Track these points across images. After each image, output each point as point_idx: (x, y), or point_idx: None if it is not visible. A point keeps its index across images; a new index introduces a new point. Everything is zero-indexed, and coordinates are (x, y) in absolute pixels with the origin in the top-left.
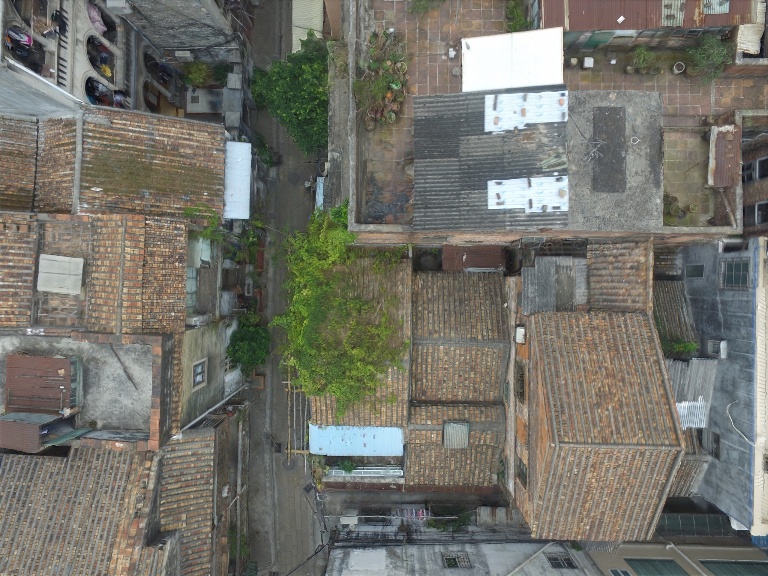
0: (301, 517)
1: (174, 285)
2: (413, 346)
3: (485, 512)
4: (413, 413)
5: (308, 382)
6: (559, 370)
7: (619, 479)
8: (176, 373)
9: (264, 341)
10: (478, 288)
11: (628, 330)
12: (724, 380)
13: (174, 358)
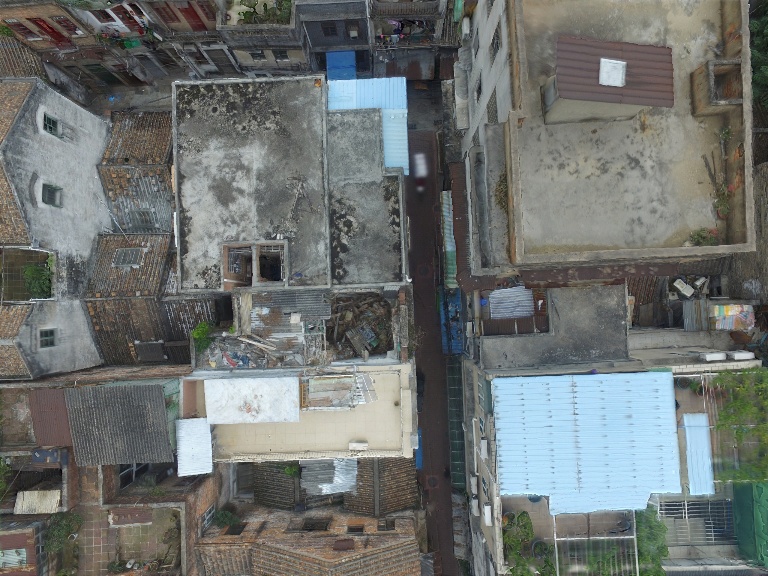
0: None
1: None
2: None
3: (458, 552)
4: None
5: None
6: None
7: None
8: None
9: None
10: None
11: (262, 567)
12: None
13: None
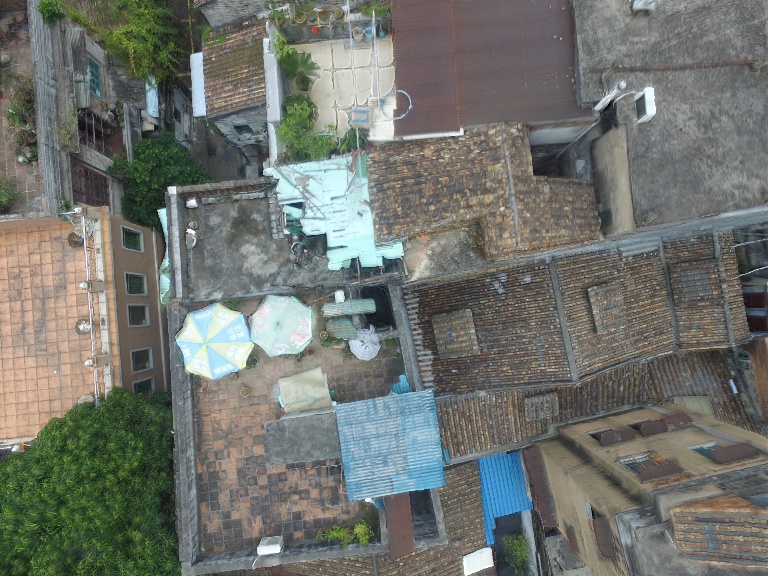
0: None
1: None
2: None
3: None
4: None
5: None
6: None
7: None
8: None
9: None
10: None
11: None
12: None
13: None
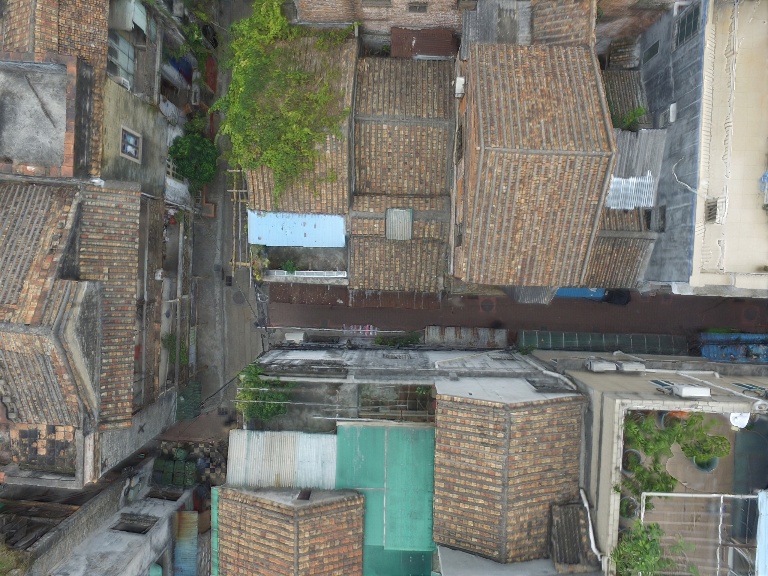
0: (251, 352)
1: (95, 16)
2: (355, 124)
3: (434, 331)
4: (355, 201)
5: (242, 150)
6: (492, 90)
7: (549, 200)
8: (96, 110)
9: (210, 151)
10: (427, 73)
11: (568, 60)
12: (672, 145)
13: (94, 94)
